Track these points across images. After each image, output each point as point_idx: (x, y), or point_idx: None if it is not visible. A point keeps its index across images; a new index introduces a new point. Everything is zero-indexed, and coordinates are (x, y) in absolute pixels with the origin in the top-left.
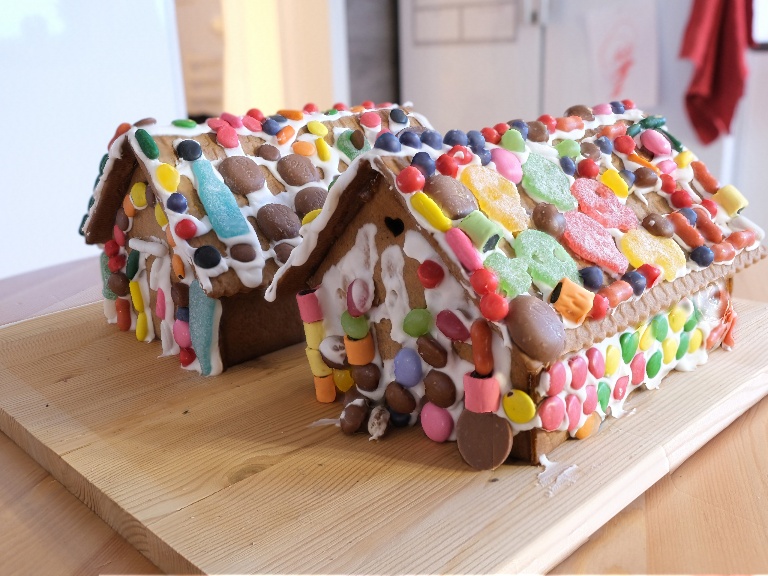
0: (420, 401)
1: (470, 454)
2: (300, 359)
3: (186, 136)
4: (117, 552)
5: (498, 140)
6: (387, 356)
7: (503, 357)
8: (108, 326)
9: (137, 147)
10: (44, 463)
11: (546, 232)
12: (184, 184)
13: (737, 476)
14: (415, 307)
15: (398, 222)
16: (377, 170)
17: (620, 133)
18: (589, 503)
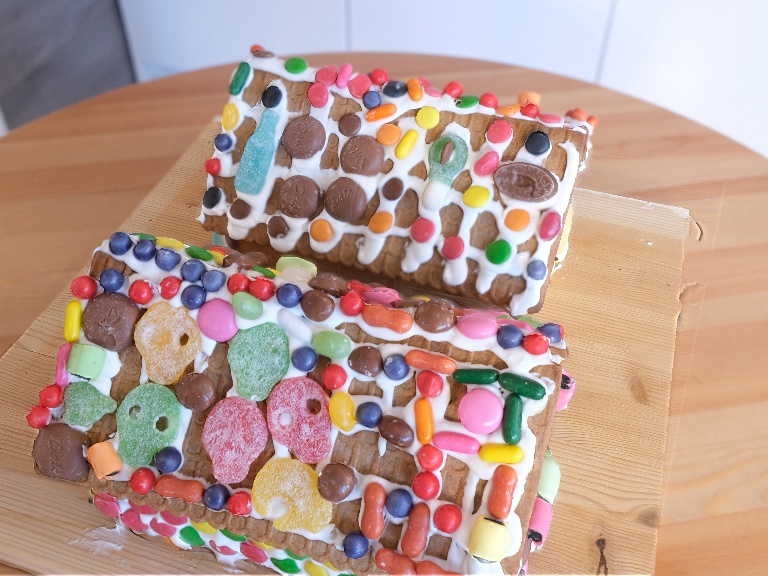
0: None
1: None
2: None
3: (287, 79)
4: None
5: None
6: None
7: None
8: None
9: None
10: None
11: None
12: (249, 125)
13: None
14: None
15: None
16: None
17: None
18: (66, 570)
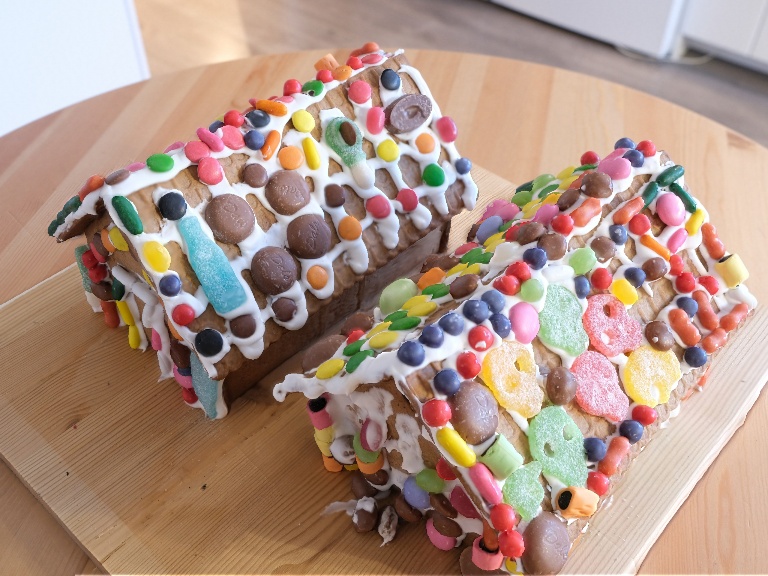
0: (426, 514)
1: None
2: None
3: (165, 181)
4: None
5: (518, 291)
6: (395, 467)
7: None
8: (95, 317)
9: (117, 221)
10: (82, 548)
11: (558, 405)
12: (172, 251)
13: (689, 564)
14: (428, 461)
15: None
16: None
17: (637, 212)
18: None
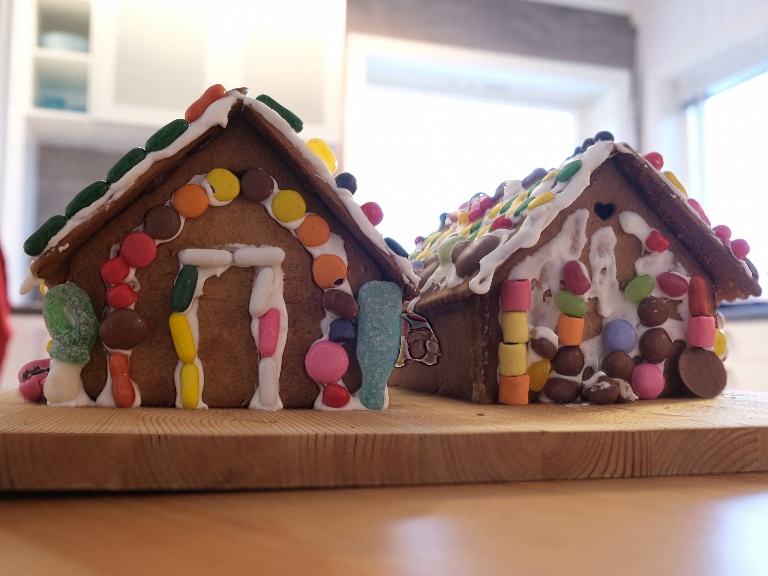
0: None
1: (701, 389)
2: None
3: None
4: (735, 476)
5: None
6: (584, 338)
7: None
8: (82, 408)
9: None
10: (480, 471)
11: None
12: None
13: None
14: (622, 281)
15: (608, 207)
16: (631, 152)
17: None
18: None
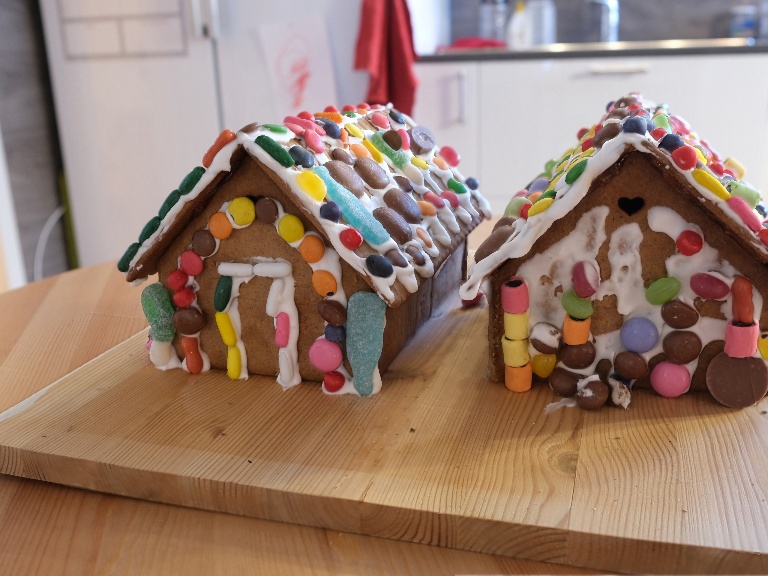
0: (649, 365)
1: (727, 397)
2: (430, 362)
3: (284, 142)
4: (524, 570)
5: None
6: (601, 331)
7: (758, 305)
8: (167, 373)
9: (268, 155)
10: (312, 520)
11: None
12: None
13: None
14: (649, 278)
15: (636, 201)
16: (649, 152)
17: None
18: None
